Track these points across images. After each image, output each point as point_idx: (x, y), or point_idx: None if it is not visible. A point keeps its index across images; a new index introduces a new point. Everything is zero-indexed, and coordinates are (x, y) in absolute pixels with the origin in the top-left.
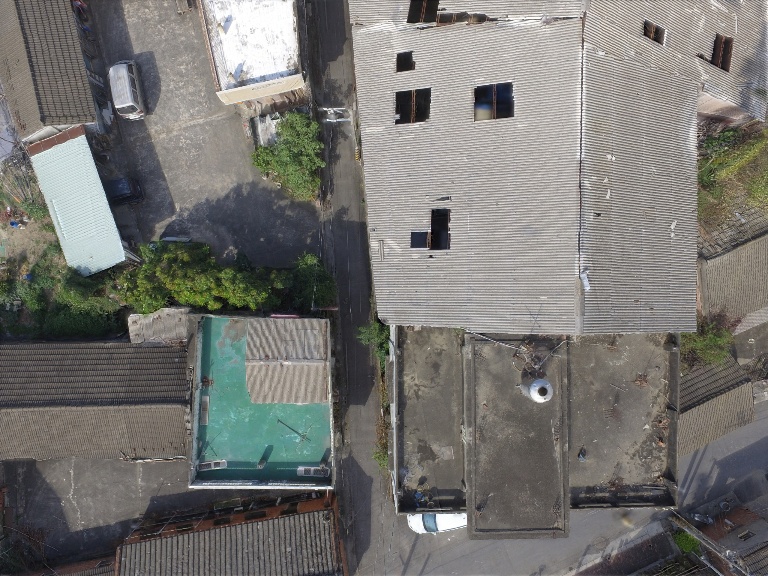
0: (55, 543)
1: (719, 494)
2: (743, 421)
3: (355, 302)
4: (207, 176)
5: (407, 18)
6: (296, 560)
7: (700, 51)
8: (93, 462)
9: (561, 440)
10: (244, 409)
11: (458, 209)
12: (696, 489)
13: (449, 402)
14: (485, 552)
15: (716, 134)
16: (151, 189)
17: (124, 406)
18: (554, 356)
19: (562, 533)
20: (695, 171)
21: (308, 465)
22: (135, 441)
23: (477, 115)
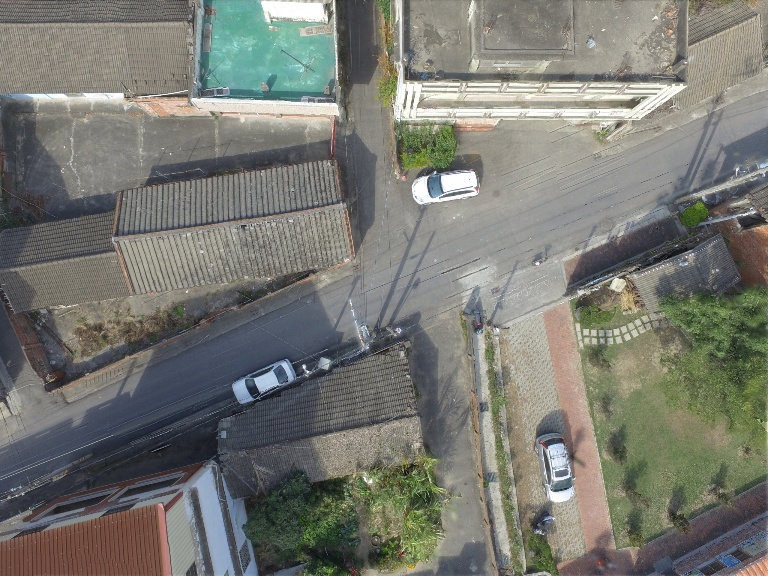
0: (55, 210)
1: None
2: (751, 71)
3: None
4: None
5: None
6: (300, 197)
7: None
8: (93, 130)
9: None
10: (247, 38)
11: None
12: (703, 174)
13: None
14: (490, 231)
15: None
16: None
17: (125, 22)
18: None
19: (572, 55)
20: None
21: (312, 95)
22: (136, 72)
23: None
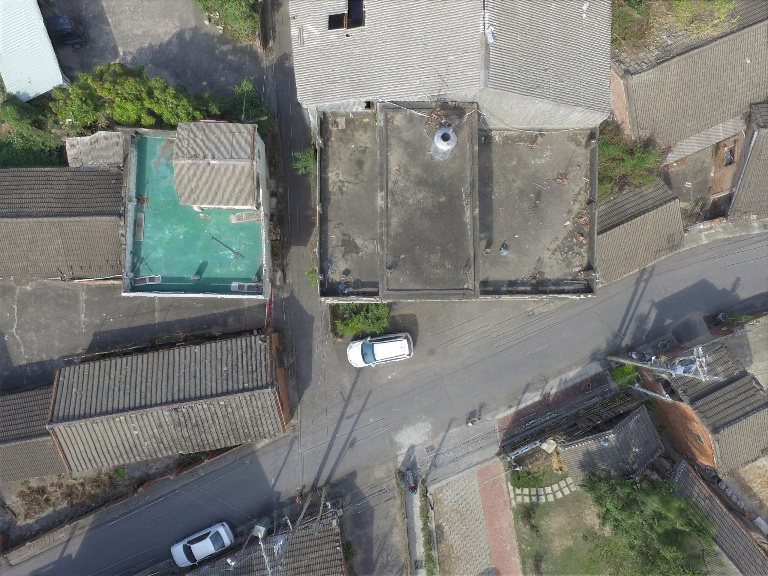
0: None
1: (657, 335)
2: (674, 246)
3: (297, 146)
4: (150, 21)
5: None
6: (231, 377)
7: None
8: (36, 298)
9: (471, 204)
10: (179, 226)
11: None
12: (634, 330)
13: (373, 198)
14: (425, 390)
15: None
16: (95, 33)
17: (58, 218)
18: (464, 121)
19: (472, 294)
20: None
21: (242, 281)
22: (72, 258)
23: None
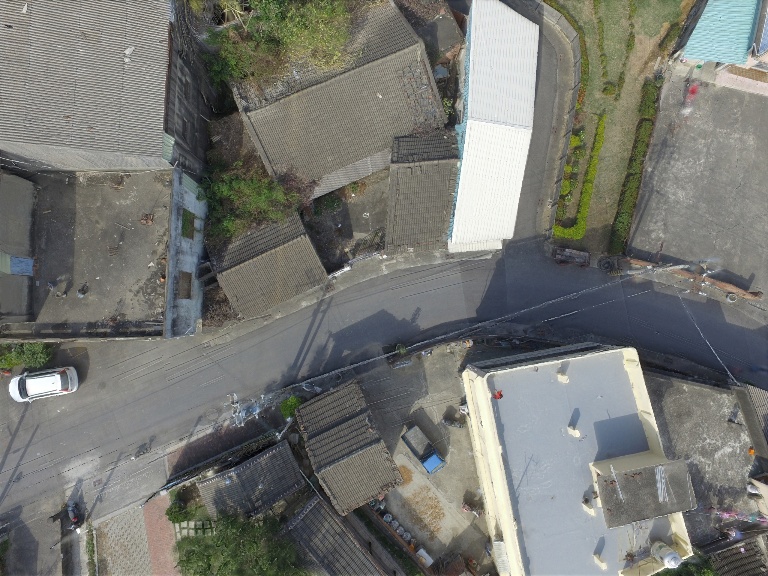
0: None
1: (335, 366)
2: (315, 280)
3: None
4: None
5: None
6: None
7: None
8: None
9: None
10: None
11: None
12: (311, 361)
13: None
14: (95, 423)
15: None
16: None
17: None
18: None
19: None
20: (165, 3)
21: None
22: None
23: None
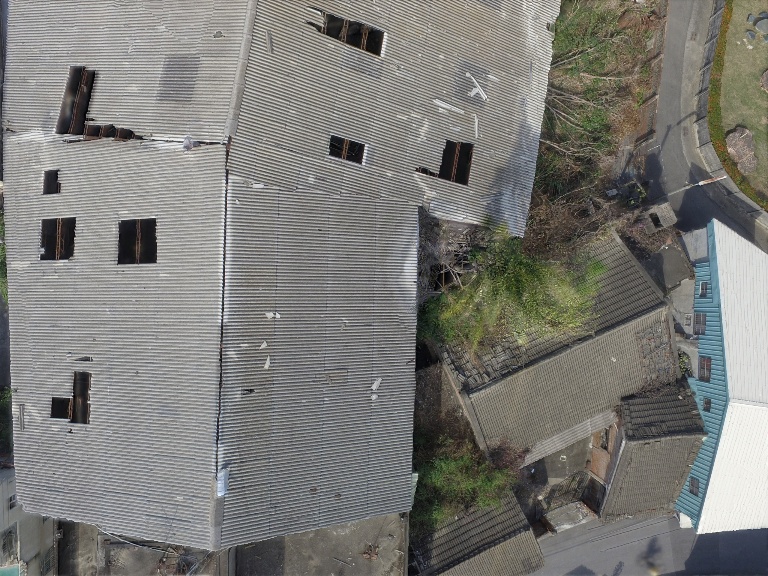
0: None
1: None
2: (531, 568)
3: None
4: None
5: (56, 127)
6: None
7: (421, 165)
8: None
9: None
10: None
11: (99, 374)
12: None
13: None
14: None
15: (484, 243)
16: None
17: None
18: None
19: None
20: (412, 313)
21: None
22: None
23: (120, 257)
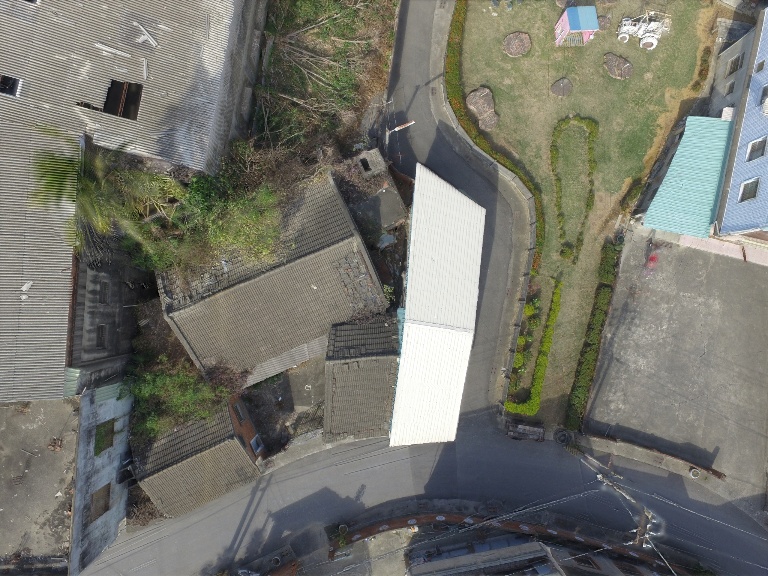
0: None
1: (274, 548)
2: (247, 478)
3: None
4: None
5: None
6: None
7: (83, 100)
8: None
9: None
10: None
11: None
12: (249, 543)
13: None
14: None
15: (189, 180)
16: None
17: None
18: None
19: None
20: (69, 228)
21: None
22: None
23: None
